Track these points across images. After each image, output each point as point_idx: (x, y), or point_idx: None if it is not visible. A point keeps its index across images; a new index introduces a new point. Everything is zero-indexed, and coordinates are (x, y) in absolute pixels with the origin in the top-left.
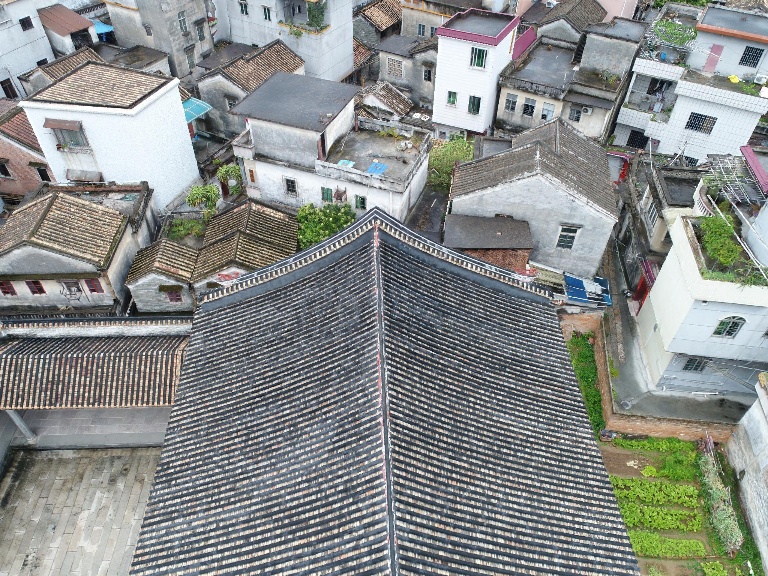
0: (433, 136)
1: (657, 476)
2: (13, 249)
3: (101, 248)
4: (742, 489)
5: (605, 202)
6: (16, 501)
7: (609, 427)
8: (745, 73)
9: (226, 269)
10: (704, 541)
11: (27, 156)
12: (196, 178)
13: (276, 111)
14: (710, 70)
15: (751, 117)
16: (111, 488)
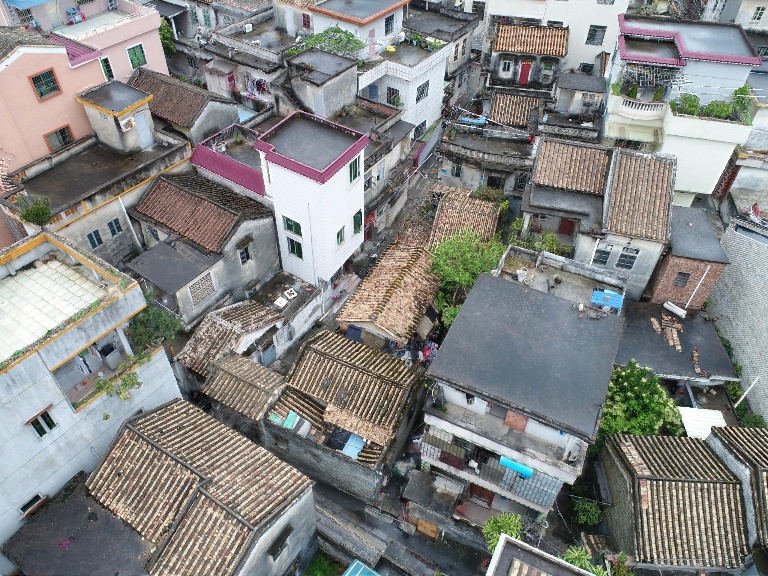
0: (319, 298)
1: None
2: None
3: None
4: None
5: None
6: None
7: None
8: (391, 40)
9: None
10: None
11: None
12: None
13: (581, 370)
14: (373, 54)
15: (442, 63)
16: None
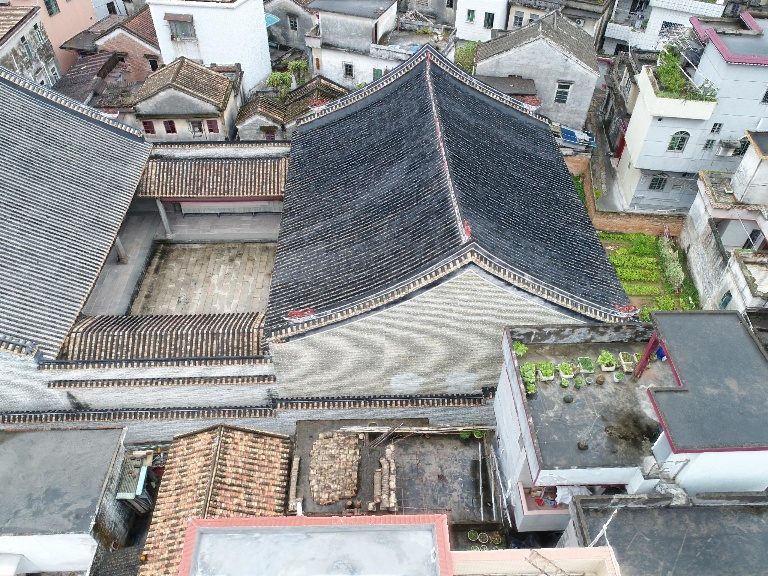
0: None
1: (627, 254)
2: (160, 91)
3: (218, 97)
4: (688, 258)
5: (590, 64)
6: (165, 270)
7: (593, 225)
8: None
9: (311, 111)
10: (659, 287)
11: (143, 49)
12: (269, 73)
13: (340, 6)
14: None
15: None
16: (231, 263)
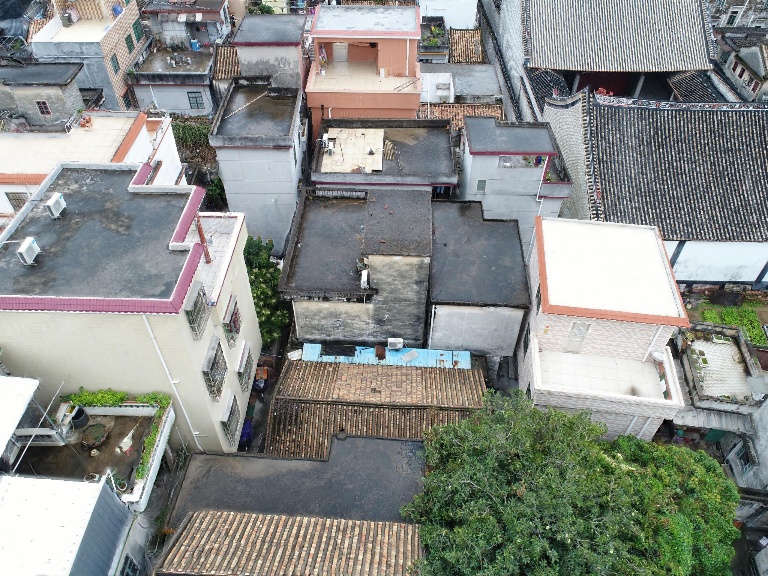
0: None
1: None
2: (754, 45)
3: None
4: None
5: None
6: None
7: None
8: None
9: None
10: None
11: None
12: None
13: None
14: None
15: None
16: None
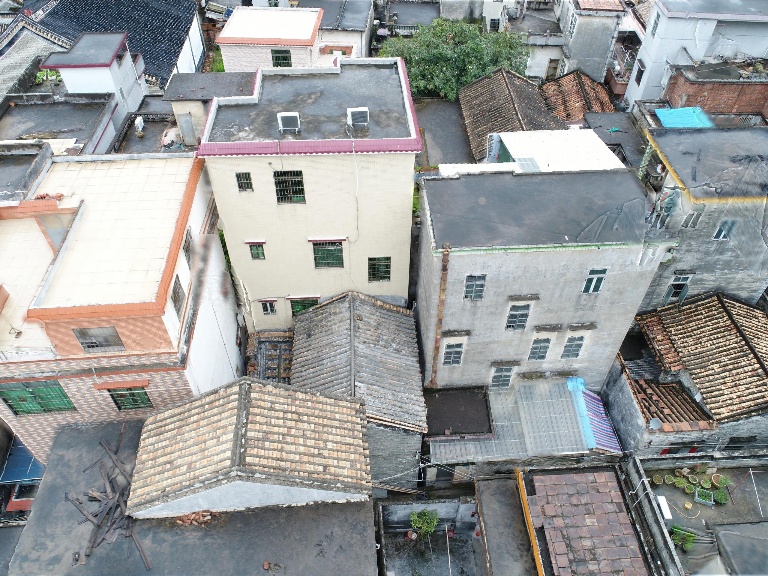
0: None
1: None
2: None
3: None
4: None
5: None
6: None
7: None
8: None
9: None
10: None
11: None
12: None
13: None
14: None
15: None
16: None
